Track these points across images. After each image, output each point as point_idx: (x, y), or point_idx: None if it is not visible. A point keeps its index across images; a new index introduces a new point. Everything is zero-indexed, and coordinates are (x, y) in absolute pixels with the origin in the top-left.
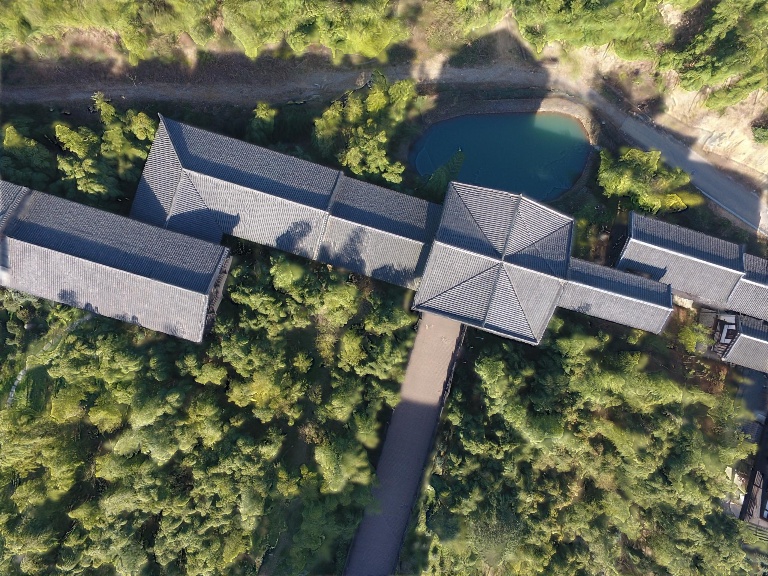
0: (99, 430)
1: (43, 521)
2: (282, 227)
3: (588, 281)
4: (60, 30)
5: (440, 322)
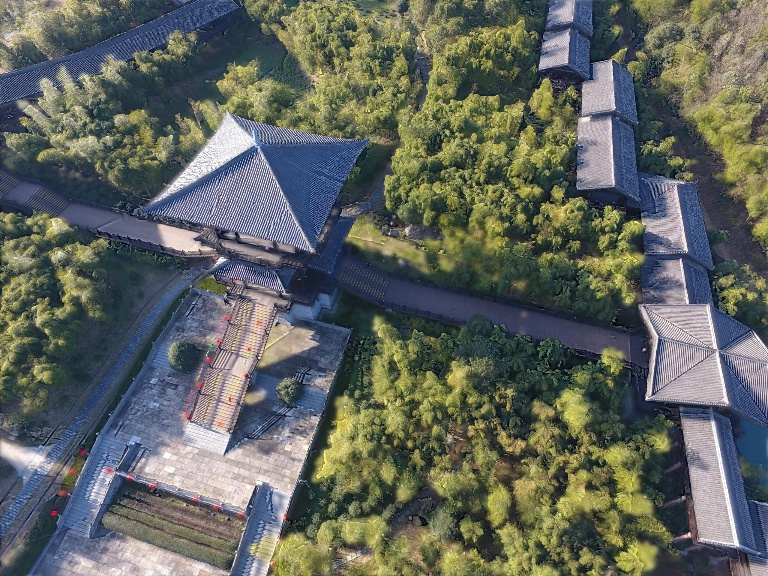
0: (518, 147)
1: (467, 126)
2: (661, 233)
3: (722, 454)
4: (716, 148)
5: (620, 346)
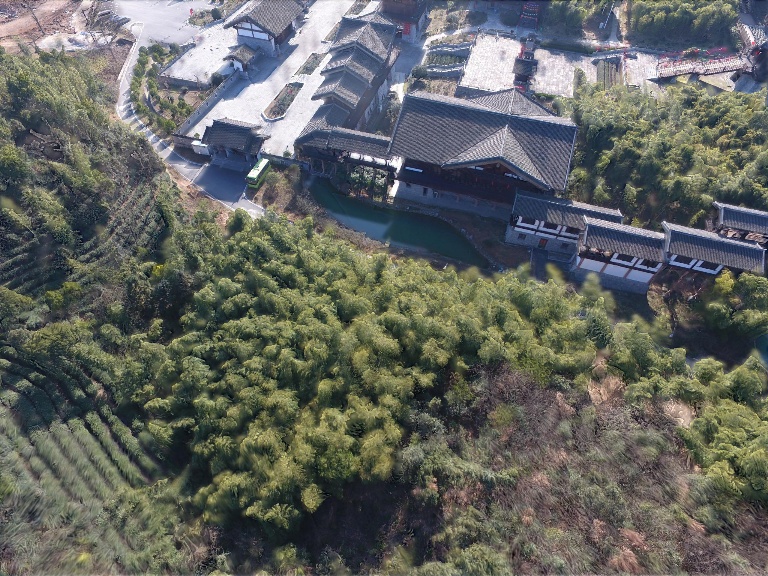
0: None
1: None
2: None
3: None
4: None
5: None
